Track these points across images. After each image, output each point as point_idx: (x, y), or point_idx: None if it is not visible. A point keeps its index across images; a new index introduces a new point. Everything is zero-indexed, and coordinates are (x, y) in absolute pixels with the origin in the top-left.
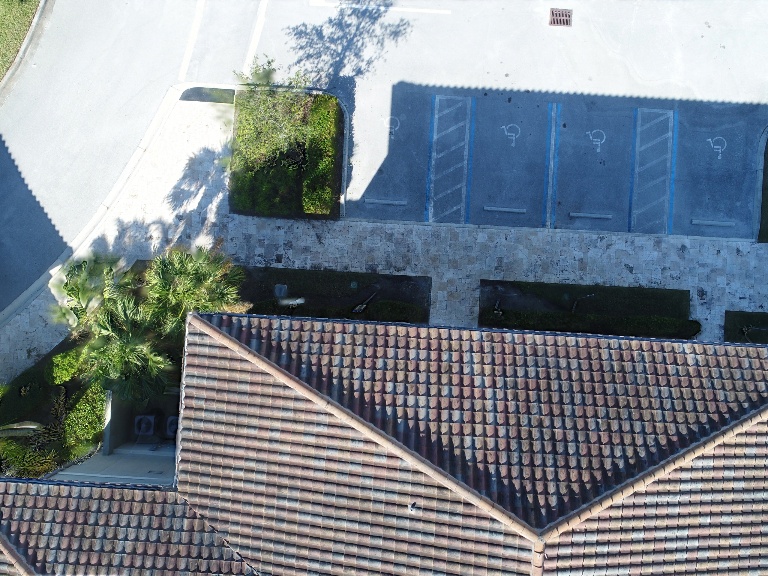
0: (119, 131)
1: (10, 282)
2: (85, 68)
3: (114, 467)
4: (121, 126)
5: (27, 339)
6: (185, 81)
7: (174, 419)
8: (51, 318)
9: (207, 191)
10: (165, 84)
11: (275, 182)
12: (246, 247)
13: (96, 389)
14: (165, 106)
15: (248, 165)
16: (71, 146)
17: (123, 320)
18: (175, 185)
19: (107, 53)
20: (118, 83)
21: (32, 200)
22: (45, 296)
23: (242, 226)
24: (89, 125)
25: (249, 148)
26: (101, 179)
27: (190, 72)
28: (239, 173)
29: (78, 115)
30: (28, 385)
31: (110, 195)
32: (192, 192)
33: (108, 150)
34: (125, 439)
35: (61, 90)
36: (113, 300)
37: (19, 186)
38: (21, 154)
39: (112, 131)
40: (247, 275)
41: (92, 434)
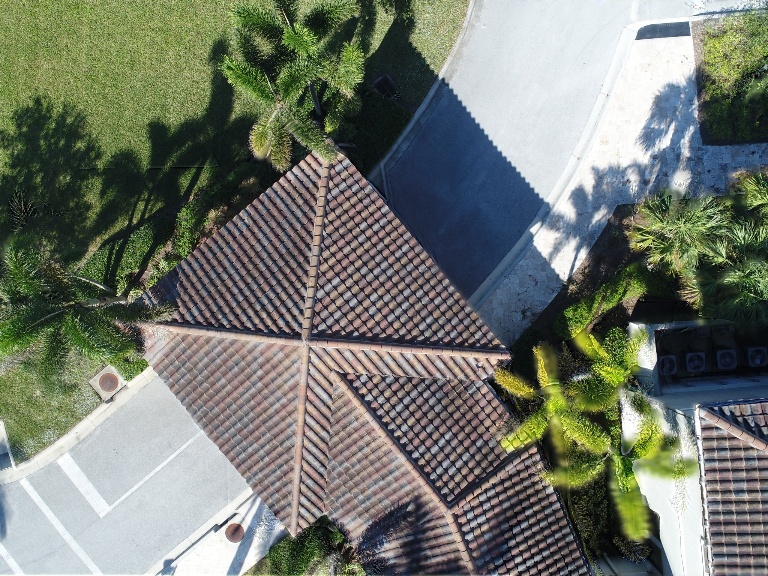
0: (579, 80)
1: (492, 246)
2: (536, 22)
3: (703, 401)
4: (580, 74)
5: (520, 300)
6: (638, 20)
7: (692, 356)
8: (541, 276)
9: (677, 126)
10: (618, 26)
11: (754, 106)
12: (724, 177)
13: (614, 336)
14: (621, 48)
15: (723, 93)
16: (534, 102)
17: (739, 245)
18: (644, 125)
19: (556, 3)
20: (572, 32)
21: (502, 161)
22: (531, 255)
23: (717, 156)
24: (549, 78)
25: (721, 76)
26: (568, 130)
27: (641, 10)
28: (716, 102)
29: (536, 70)
30: (538, 344)
31: (579, 145)
32: (662, 130)
33: (571, 100)
34: (661, 380)
35: (515, 47)
36: (724, 227)
37: (488, 149)
38: (485, 117)
39: (572, 81)
40: (731, 204)
41: (617, 382)
